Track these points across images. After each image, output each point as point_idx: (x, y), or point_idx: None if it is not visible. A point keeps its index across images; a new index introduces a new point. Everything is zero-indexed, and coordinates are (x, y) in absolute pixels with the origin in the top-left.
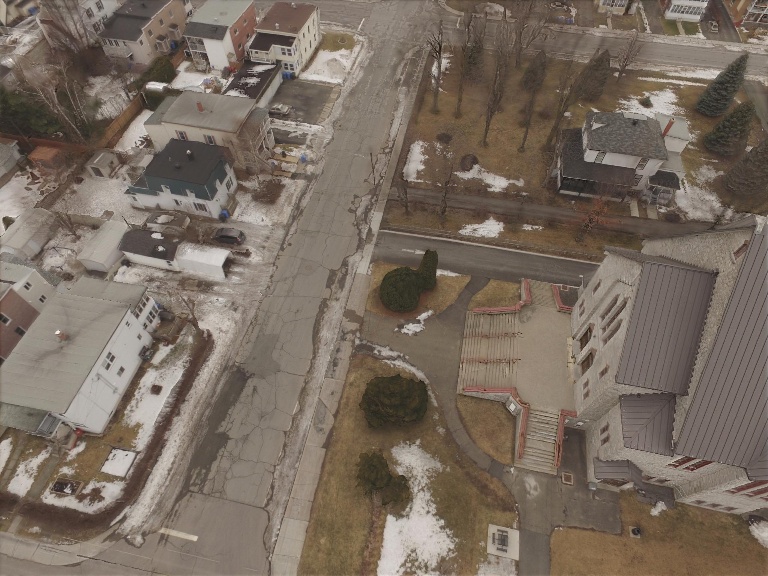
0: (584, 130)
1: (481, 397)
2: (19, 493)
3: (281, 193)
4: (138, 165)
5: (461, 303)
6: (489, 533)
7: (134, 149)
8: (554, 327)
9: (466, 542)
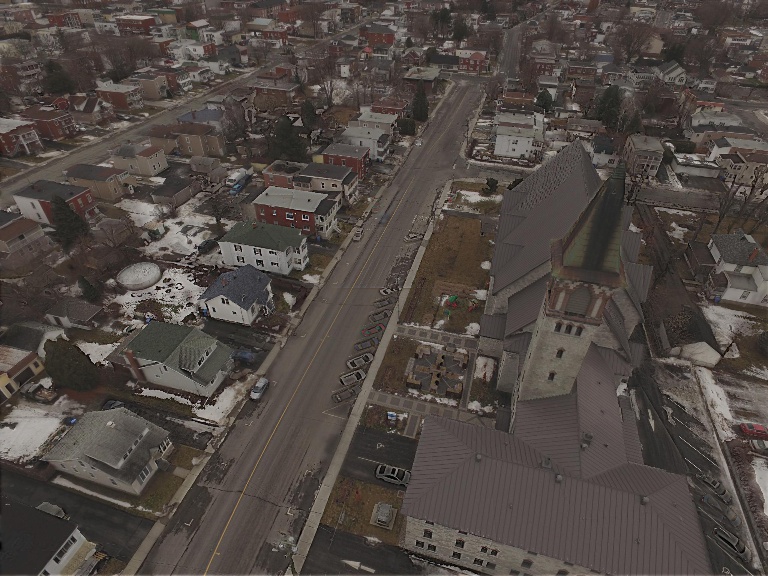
0: None
1: None
2: None
3: None
4: None
5: None
6: None
7: None
8: None
9: None
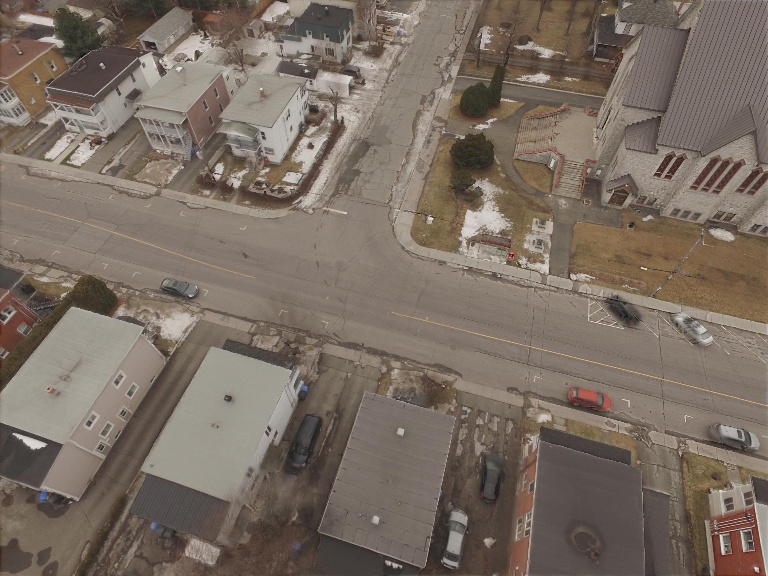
0: (617, 13)
1: (530, 161)
2: (234, 186)
3: (384, 52)
4: (284, 24)
5: (517, 115)
6: (533, 222)
7: (278, 17)
8: (584, 122)
9: (518, 224)
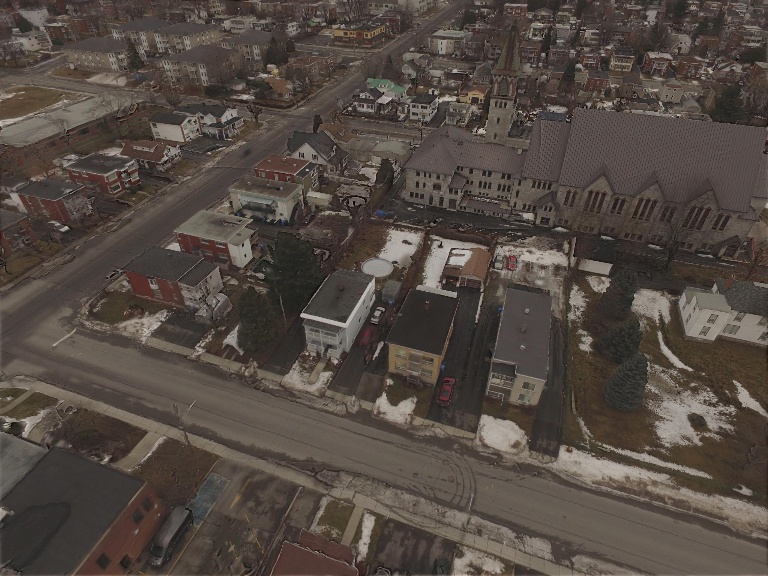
0: None
1: None
2: None
3: None
4: None
5: None
6: None
7: None
8: None
9: None
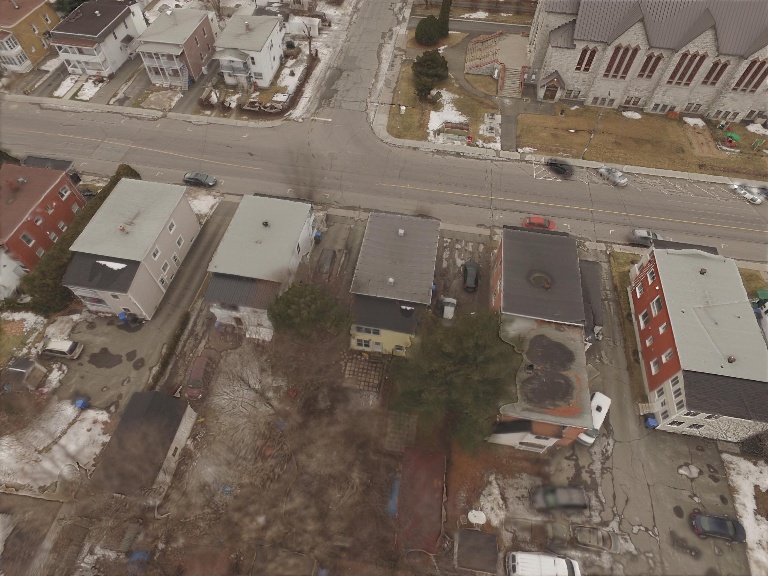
0: None
1: (478, 74)
2: (231, 106)
3: (344, 1)
4: None
5: (464, 42)
6: (485, 116)
7: None
8: (519, 42)
9: (473, 118)
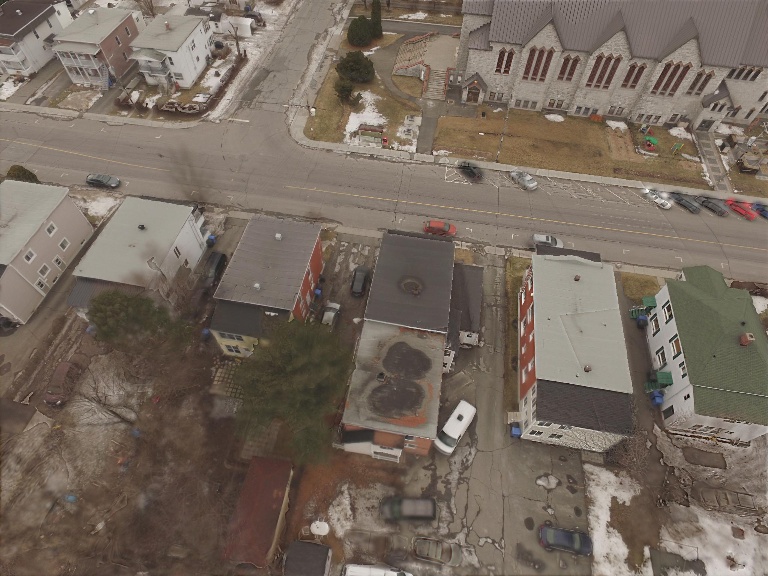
0: None
1: (406, 75)
2: (149, 107)
3: (283, 1)
4: None
5: (397, 43)
6: None
7: None
8: (449, 43)
9: (393, 120)
